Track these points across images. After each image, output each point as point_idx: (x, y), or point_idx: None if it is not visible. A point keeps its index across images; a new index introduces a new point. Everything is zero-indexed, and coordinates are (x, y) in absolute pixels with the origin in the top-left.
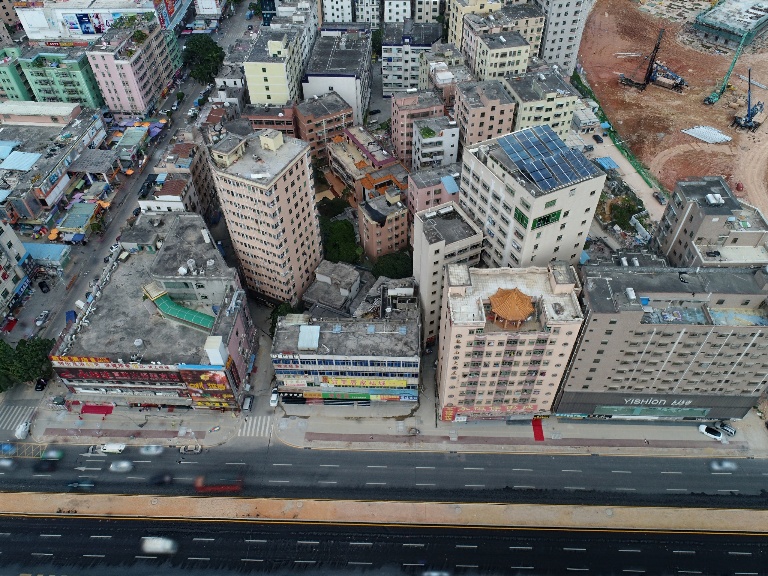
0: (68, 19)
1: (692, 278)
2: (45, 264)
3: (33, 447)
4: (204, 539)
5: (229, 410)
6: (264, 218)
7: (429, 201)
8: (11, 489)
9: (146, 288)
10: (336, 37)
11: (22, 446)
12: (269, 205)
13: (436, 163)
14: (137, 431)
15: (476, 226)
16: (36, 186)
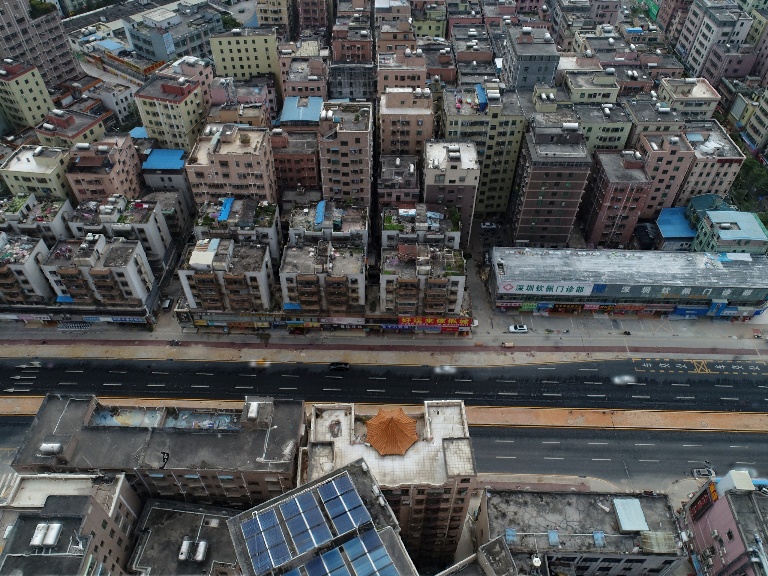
0: None
1: (151, 460)
2: None
3: None
4: (641, 397)
5: None
6: None
7: None
8: None
9: None
10: None
11: None
12: None
13: None
14: None
15: None
16: None
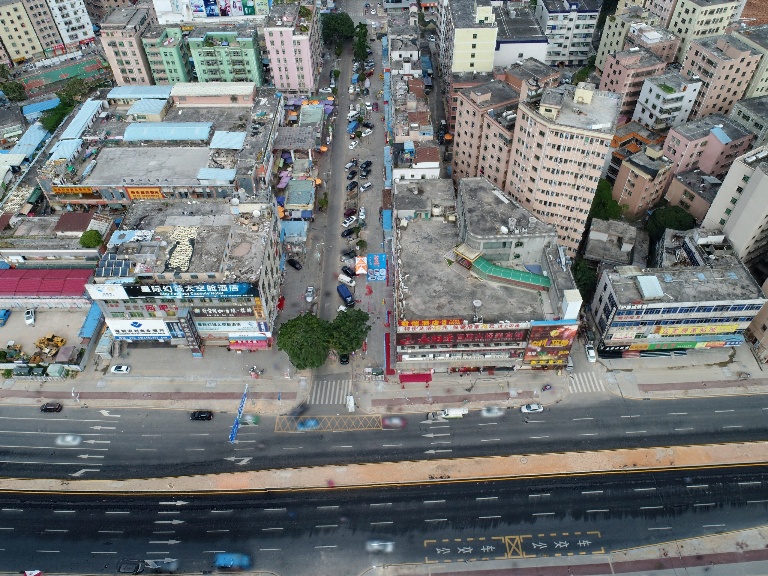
0: (193, 2)
1: None
2: (292, 241)
3: (368, 419)
4: (593, 492)
5: (551, 369)
6: (589, 171)
7: (693, 154)
8: (368, 461)
9: (459, 251)
10: (498, 7)
11: (356, 419)
12: (604, 156)
13: (671, 120)
14: (467, 396)
15: None
16: (259, 163)
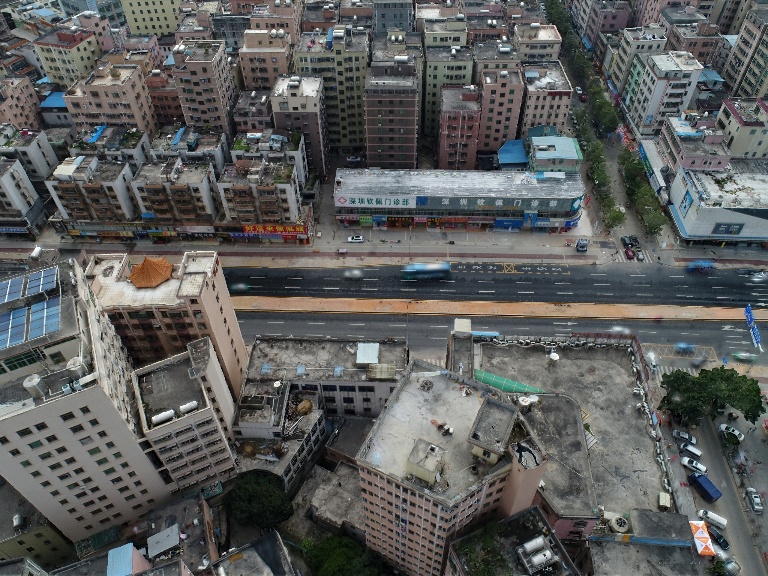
0: None
1: None
2: None
3: None
4: (447, 291)
5: None
6: None
7: None
8: (622, 321)
9: (582, 412)
10: None
11: (643, 353)
12: None
13: None
14: None
15: (135, 384)
16: None
